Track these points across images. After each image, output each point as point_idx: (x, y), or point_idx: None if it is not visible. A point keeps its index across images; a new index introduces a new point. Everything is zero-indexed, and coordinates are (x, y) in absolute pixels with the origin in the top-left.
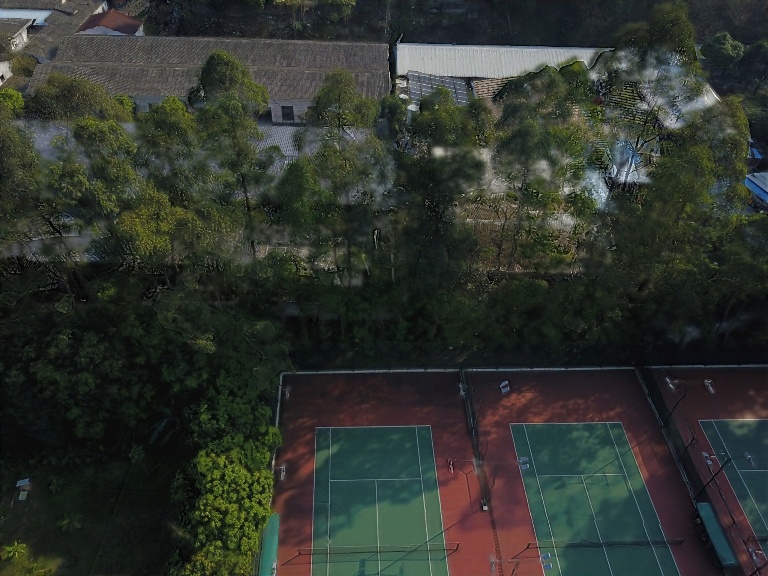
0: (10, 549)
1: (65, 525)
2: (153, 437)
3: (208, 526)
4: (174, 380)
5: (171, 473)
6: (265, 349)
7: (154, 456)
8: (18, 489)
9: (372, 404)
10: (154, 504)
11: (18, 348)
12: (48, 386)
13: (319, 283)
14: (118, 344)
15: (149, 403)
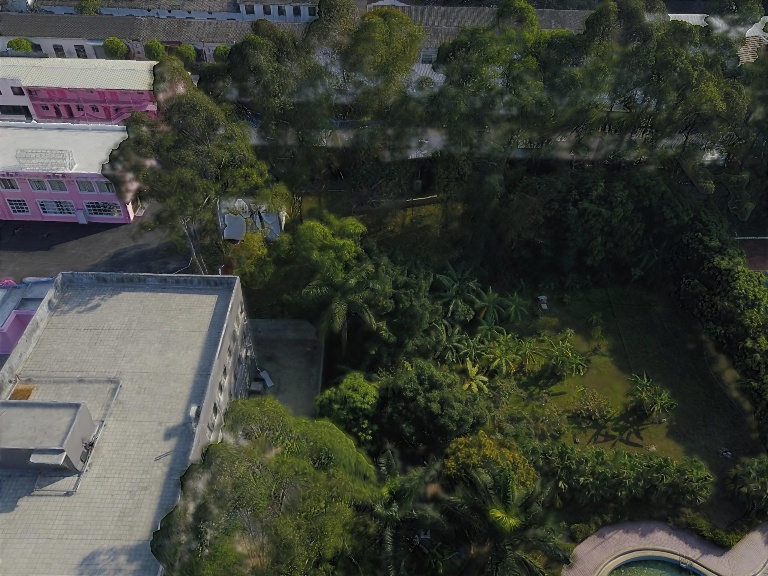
0: (568, 331)
1: (595, 319)
2: (643, 263)
3: (744, 300)
4: (673, 217)
5: (641, 294)
6: (742, 193)
7: (621, 285)
8: (539, 302)
9: (757, 257)
10: (641, 312)
11: (563, 194)
12: (592, 218)
13: (722, 165)
14: (634, 191)
15: (638, 239)
